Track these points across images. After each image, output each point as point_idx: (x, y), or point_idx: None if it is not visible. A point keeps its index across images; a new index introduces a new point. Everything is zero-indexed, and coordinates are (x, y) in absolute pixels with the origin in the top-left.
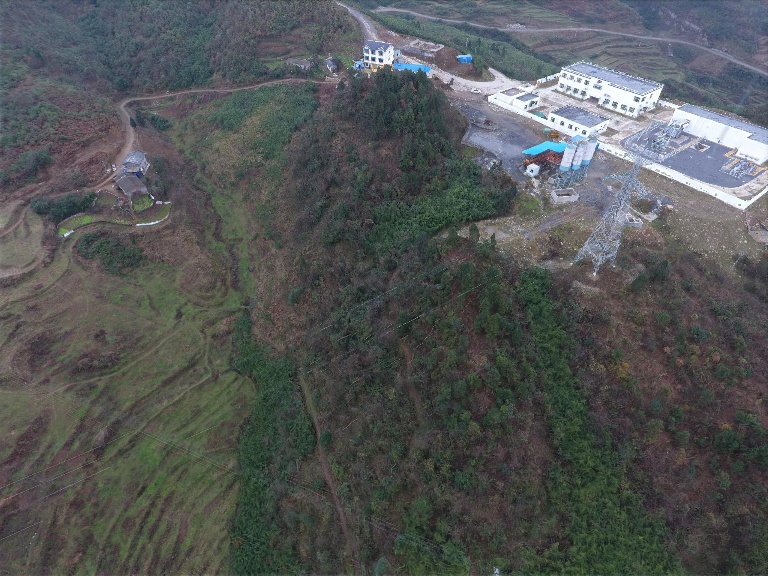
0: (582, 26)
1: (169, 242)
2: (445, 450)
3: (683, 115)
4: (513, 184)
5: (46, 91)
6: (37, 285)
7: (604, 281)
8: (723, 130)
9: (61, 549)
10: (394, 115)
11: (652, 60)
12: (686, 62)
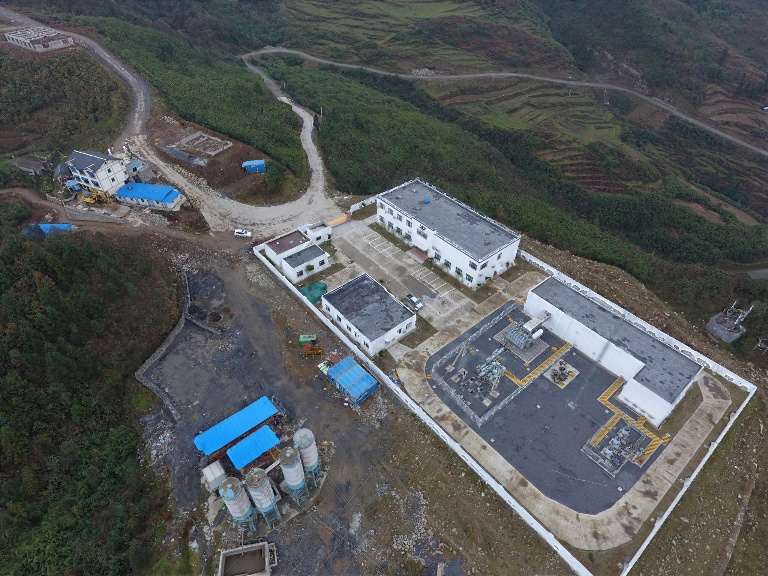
0: (503, 70)
1: None
2: None
3: (540, 303)
4: None
5: None
6: None
7: None
8: (599, 344)
9: None
10: None
11: (583, 111)
12: (624, 113)
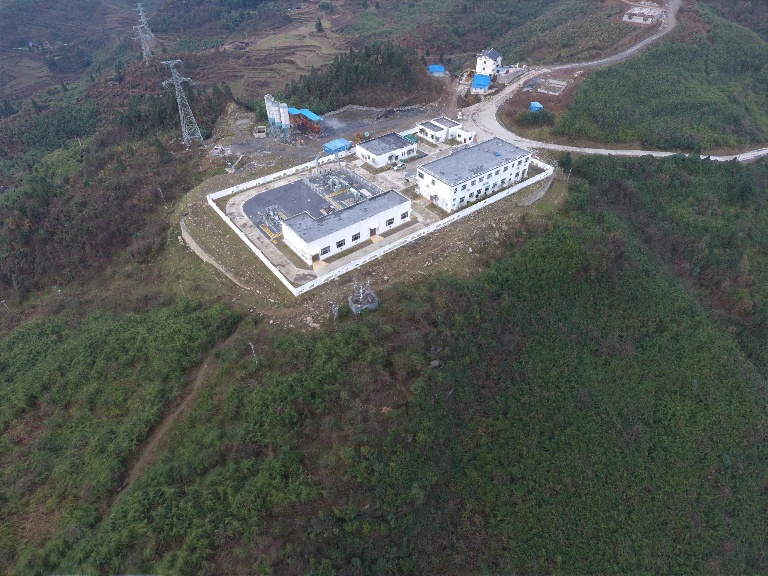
0: None
1: None
2: None
3: None
4: None
5: (427, 20)
6: (295, 72)
7: None
8: None
9: None
10: None
11: None
12: None
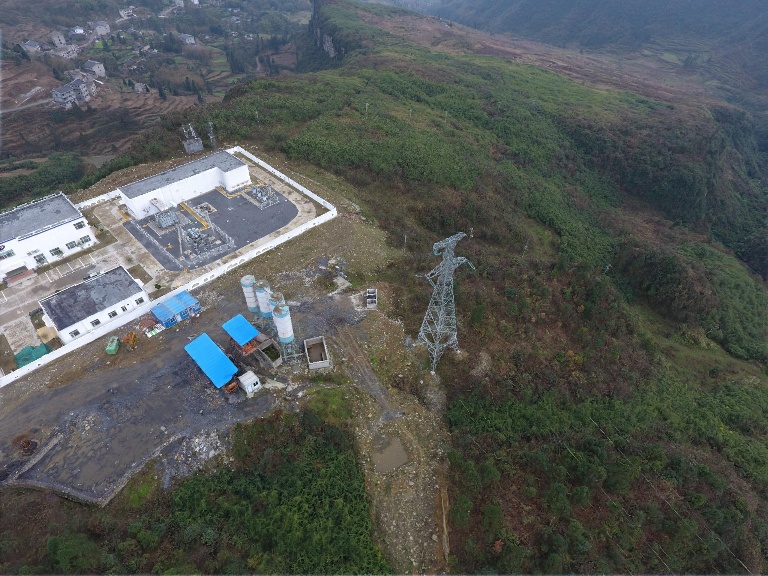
0: None
1: None
2: (753, 546)
3: (143, 199)
4: (308, 413)
5: None
6: None
7: (466, 346)
8: (192, 182)
9: None
10: None
11: None
12: None
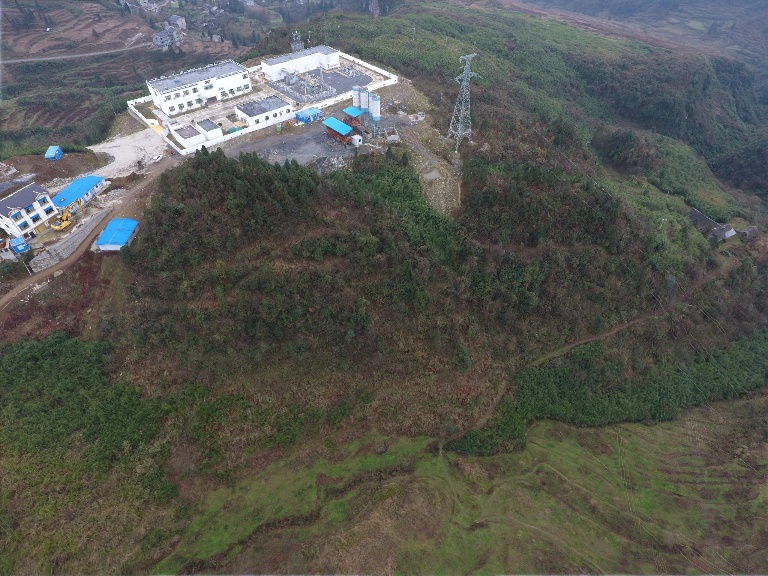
0: None
1: (361, 571)
2: None
3: (277, 67)
4: (390, 147)
5: None
6: None
7: None
8: (305, 61)
9: (767, 532)
10: (305, 179)
11: None
12: None
